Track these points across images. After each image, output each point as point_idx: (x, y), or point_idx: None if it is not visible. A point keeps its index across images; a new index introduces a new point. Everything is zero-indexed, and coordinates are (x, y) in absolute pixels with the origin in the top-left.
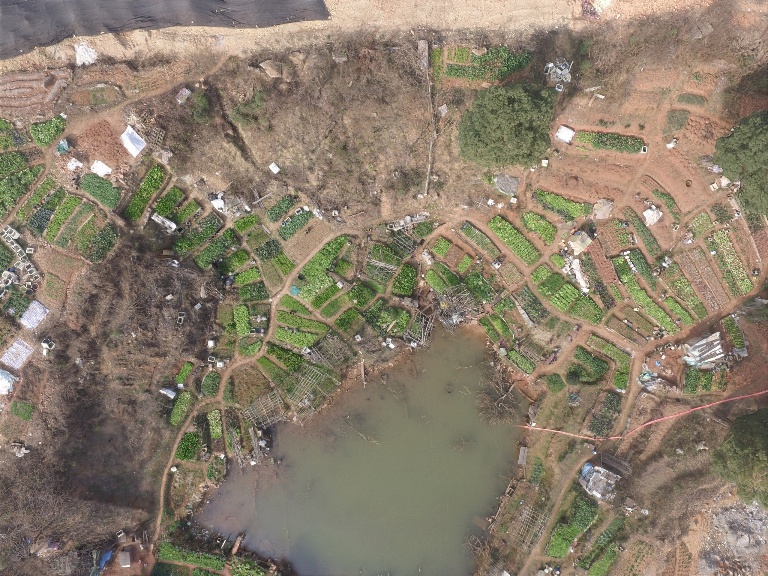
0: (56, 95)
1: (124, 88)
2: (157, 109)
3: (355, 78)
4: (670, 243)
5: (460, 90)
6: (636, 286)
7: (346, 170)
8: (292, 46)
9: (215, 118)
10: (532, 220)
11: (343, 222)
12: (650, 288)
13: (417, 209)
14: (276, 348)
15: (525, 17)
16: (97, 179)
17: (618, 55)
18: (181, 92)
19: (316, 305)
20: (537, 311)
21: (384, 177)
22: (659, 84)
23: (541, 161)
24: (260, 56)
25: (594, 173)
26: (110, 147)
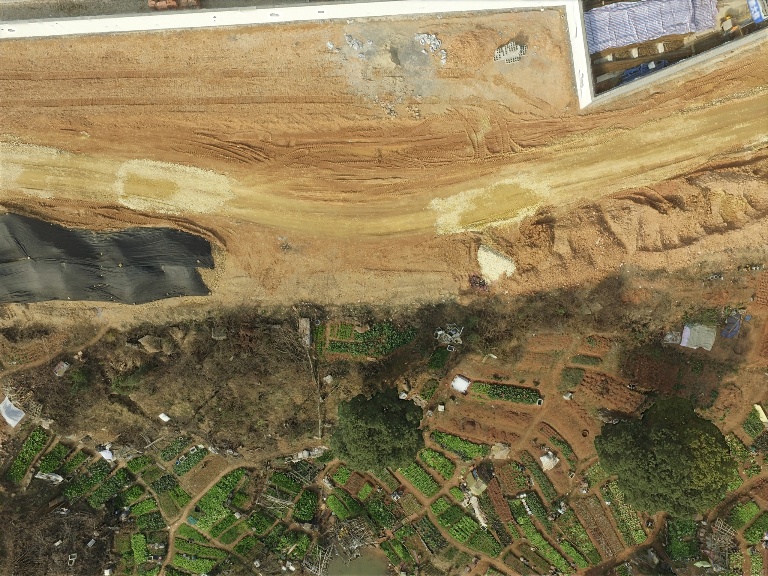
0: None
1: (2, 359)
2: (35, 381)
3: (236, 353)
4: (566, 488)
5: (345, 362)
6: (532, 529)
7: (236, 422)
8: (172, 320)
9: (97, 384)
10: (430, 457)
11: (240, 456)
12: (546, 531)
13: (315, 443)
14: (175, 573)
15: (410, 293)
16: None
17: (509, 323)
18: (59, 366)
19: (214, 534)
20: (436, 542)
21: (277, 424)
22: (552, 348)
23: (438, 406)
24: (140, 329)
25: (491, 419)
26: None
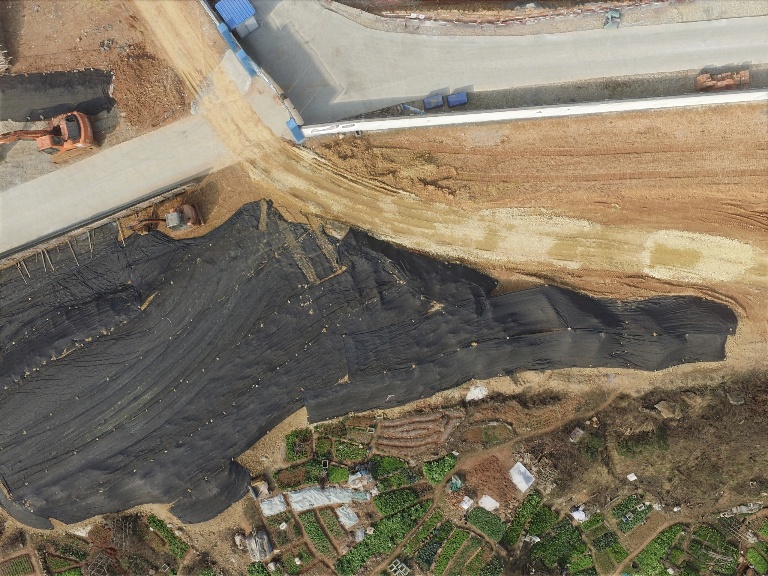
0: (450, 434)
1: (515, 426)
2: (548, 447)
3: (747, 417)
4: None
5: None
6: None
7: (705, 481)
8: (685, 385)
9: None
10: None
11: (678, 512)
12: None
13: (751, 498)
14: None
15: None
16: (486, 514)
17: None
18: (574, 432)
19: None
20: None
21: (736, 482)
22: None
23: None
24: (652, 395)
25: None
26: (499, 482)
